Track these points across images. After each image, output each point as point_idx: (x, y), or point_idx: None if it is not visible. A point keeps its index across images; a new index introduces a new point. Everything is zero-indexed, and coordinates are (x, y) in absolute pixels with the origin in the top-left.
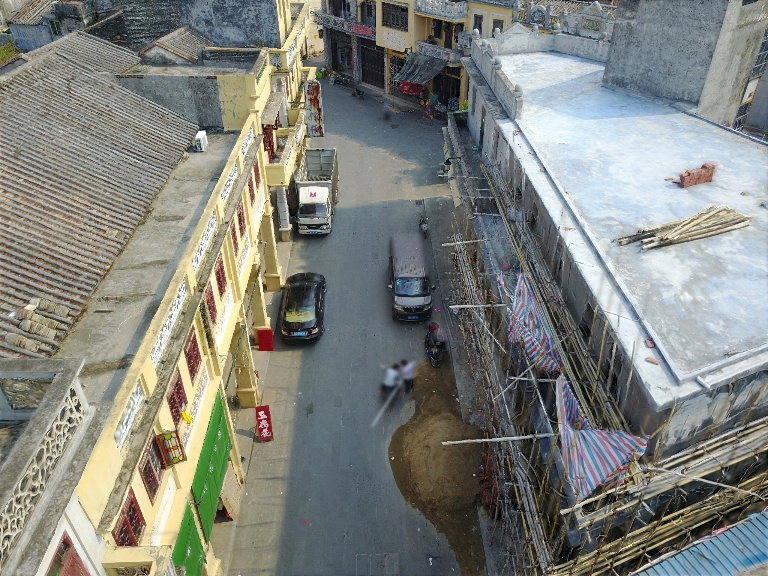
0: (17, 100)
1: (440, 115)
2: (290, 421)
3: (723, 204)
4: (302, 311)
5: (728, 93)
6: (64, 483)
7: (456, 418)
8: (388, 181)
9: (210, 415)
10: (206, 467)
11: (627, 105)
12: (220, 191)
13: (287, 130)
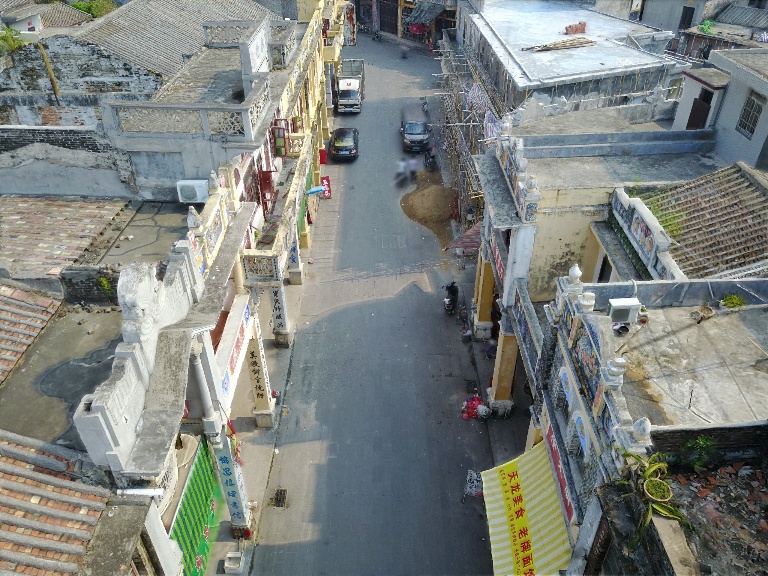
0: None
1: None
2: (341, 192)
3: None
4: (345, 141)
5: (619, 1)
6: None
7: None
8: (400, 88)
9: None
10: None
11: (553, 7)
12: (308, 35)
13: (334, 32)
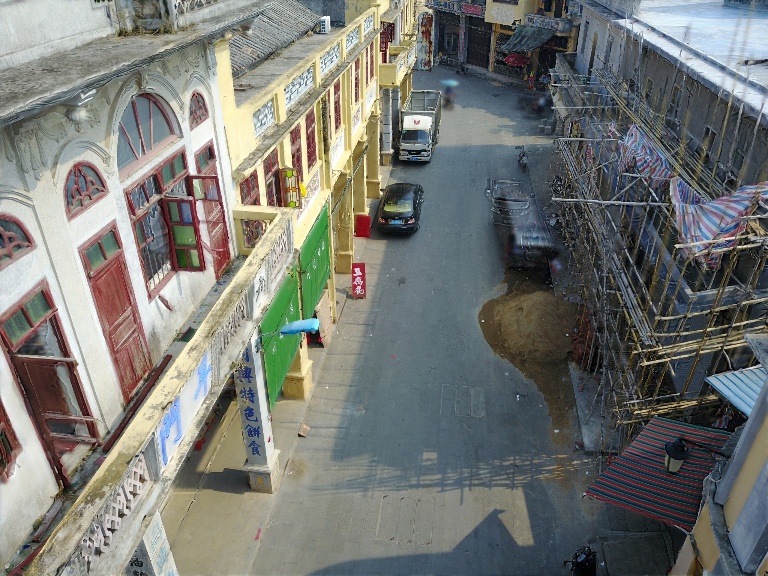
0: None
1: (543, 87)
2: (382, 287)
3: None
4: (400, 204)
5: None
6: (235, 11)
7: (550, 293)
8: (488, 131)
9: (320, 210)
10: (312, 252)
11: (751, 14)
12: (345, 32)
13: (400, 48)
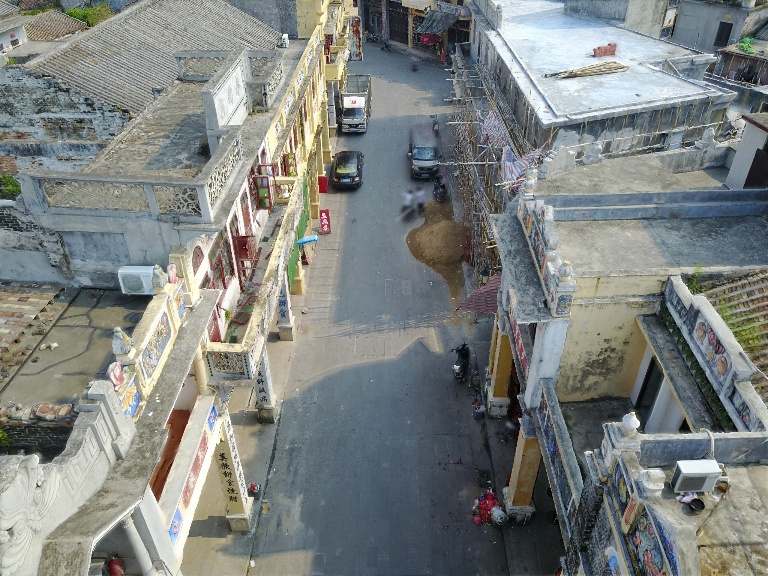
0: (176, 4)
1: None
2: (341, 225)
3: None
4: (348, 167)
5: (650, 16)
6: None
7: (451, 221)
8: (409, 104)
9: None
10: None
11: (577, 23)
12: (306, 56)
13: (338, 47)
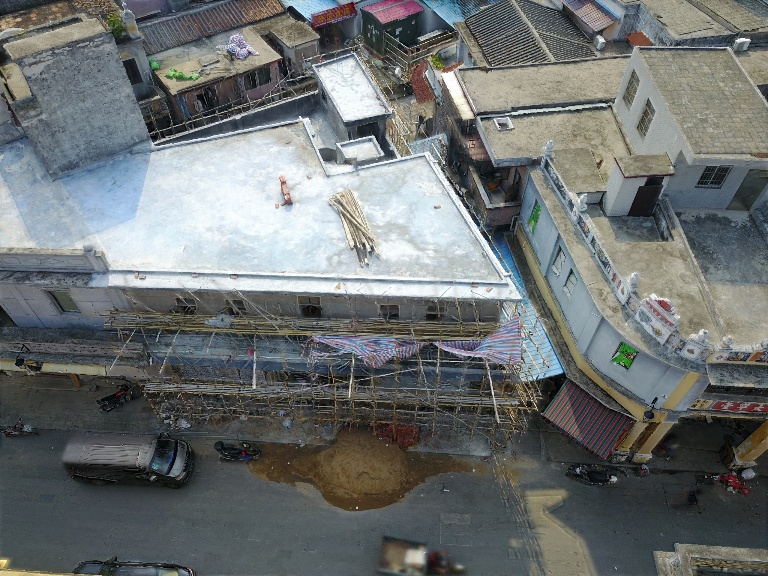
0: None
1: None
2: None
3: (321, 193)
4: None
5: None
6: None
7: (332, 448)
8: None
9: None
10: None
11: (114, 179)
12: None
13: None
